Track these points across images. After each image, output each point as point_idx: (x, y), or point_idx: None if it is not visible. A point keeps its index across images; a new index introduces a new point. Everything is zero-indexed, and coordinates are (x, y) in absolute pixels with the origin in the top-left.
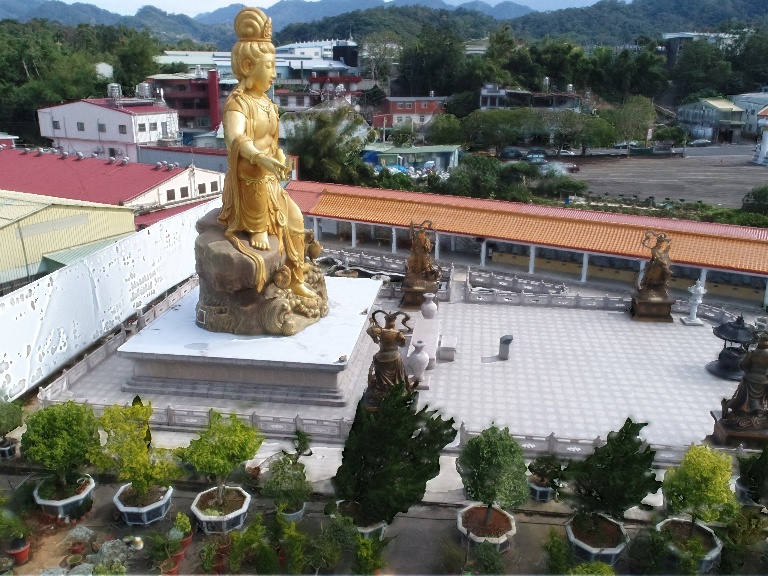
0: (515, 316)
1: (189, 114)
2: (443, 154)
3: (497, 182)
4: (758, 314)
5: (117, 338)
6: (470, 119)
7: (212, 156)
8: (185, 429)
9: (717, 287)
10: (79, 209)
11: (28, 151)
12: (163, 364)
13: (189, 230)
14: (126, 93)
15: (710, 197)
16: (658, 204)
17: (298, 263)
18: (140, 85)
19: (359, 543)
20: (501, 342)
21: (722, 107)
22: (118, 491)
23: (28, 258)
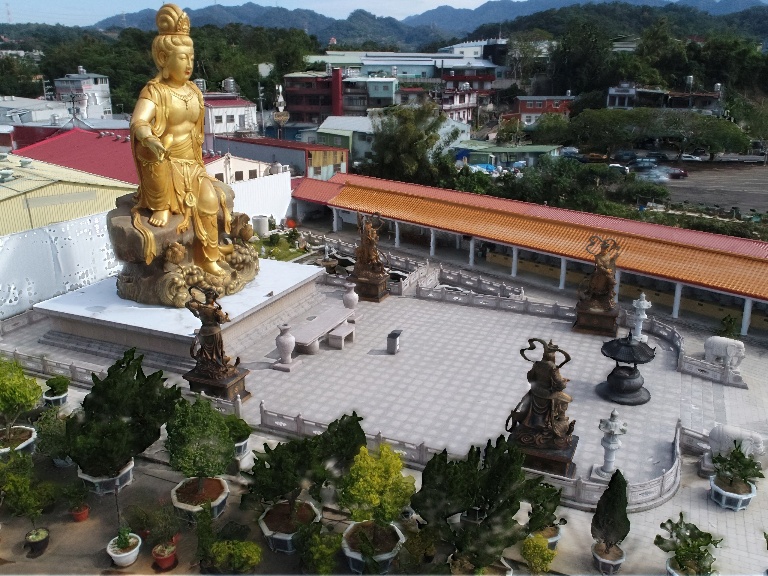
0: (450, 315)
1: (315, 110)
2: (536, 154)
3: (571, 184)
4: None
5: None
6: (578, 119)
7: (267, 147)
8: None
9: (702, 306)
10: (87, 186)
11: (119, 138)
12: (68, 322)
13: None
14: (216, 88)
15: None
16: (744, 216)
17: (206, 242)
18: (226, 81)
19: (8, 479)
20: (388, 336)
21: None
22: None
23: (35, 226)
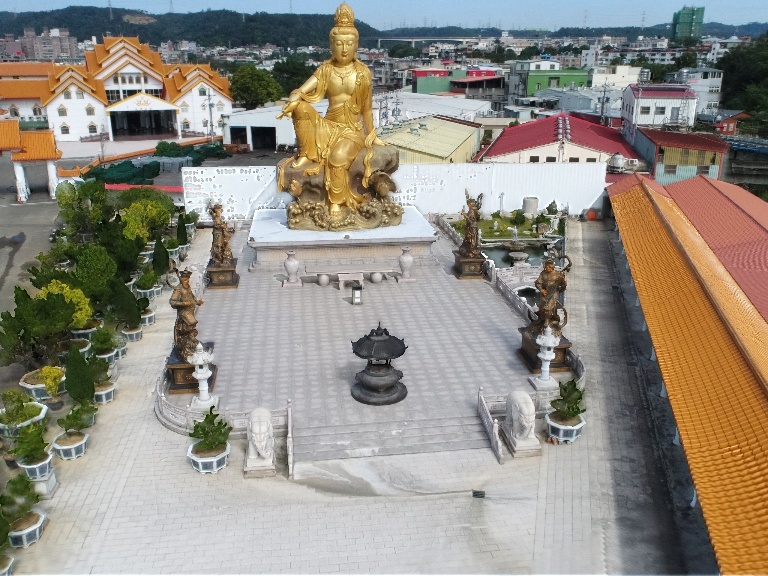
0: (473, 304)
1: None
2: None
3: None
4: (643, 435)
5: None
6: None
7: None
8: None
9: None
10: (399, 148)
11: None
12: None
13: (458, 179)
14: None
15: None
16: None
17: (328, 187)
18: (679, 71)
19: None
20: None
21: None
22: None
23: None
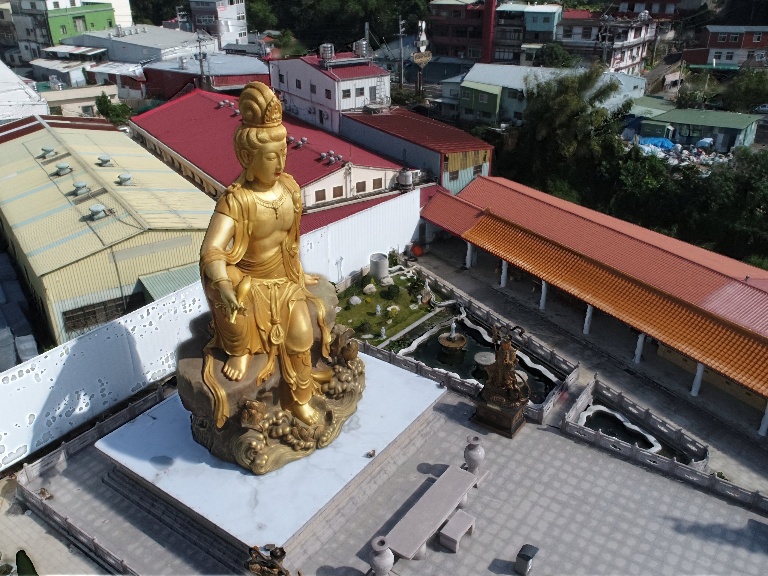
0: (604, 482)
1: (461, 43)
2: (728, 130)
3: None
4: None
5: (149, 398)
6: None
7: (398, 139)
8: (105, 566)
9: None
10: (181, 231)
11: (238, 113)
12: None
13: None
14: None
15: None
16: None
17: (295, 385)
18: (357, 43)
19: None
20: (518, 554)
21: None
22: None
23: (122, 280)
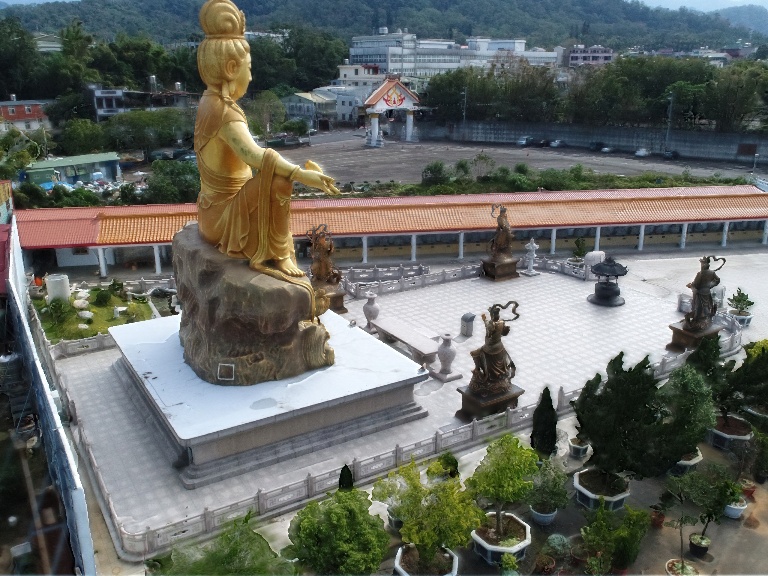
0: (415, 300)
1: None
2: (108, 163)
3: None
4: (554, 258)
5: None
6: (113, 123)
7: None
8: None
9: (510, 244)
10: None
11: None
12: (234, 438)
13: None
14: None
15: (384, 177)
16: (357, 188)
17: None
18: None
19: None
20: (468, 321)
21: (329, 99)
22: (402, 572)
23: None
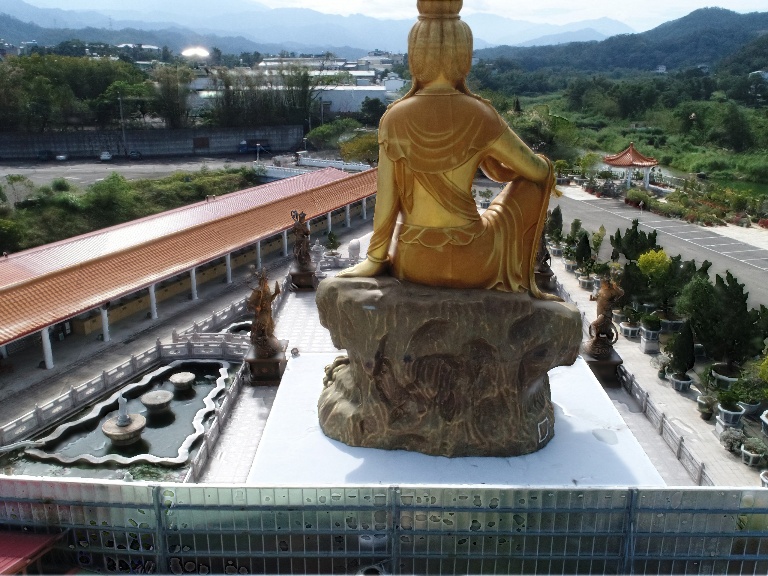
0: (309, 330)
1: None
2: None
3: None
4: None
5: None
6: None
7: None
8: None
9: (246, 257)
10: None
11: None
12: None
13: None
14: None
15: None
16: None
17: None
18: None
19: None
20: None
21: None
22: None
23: None
